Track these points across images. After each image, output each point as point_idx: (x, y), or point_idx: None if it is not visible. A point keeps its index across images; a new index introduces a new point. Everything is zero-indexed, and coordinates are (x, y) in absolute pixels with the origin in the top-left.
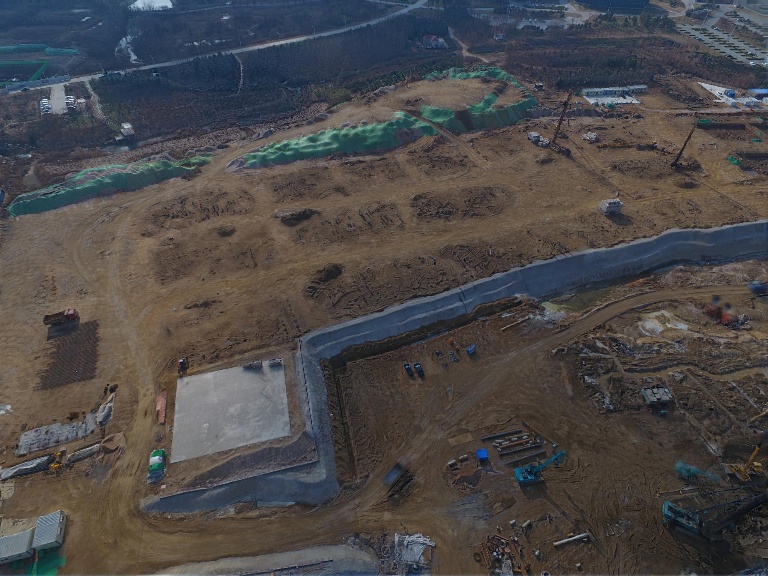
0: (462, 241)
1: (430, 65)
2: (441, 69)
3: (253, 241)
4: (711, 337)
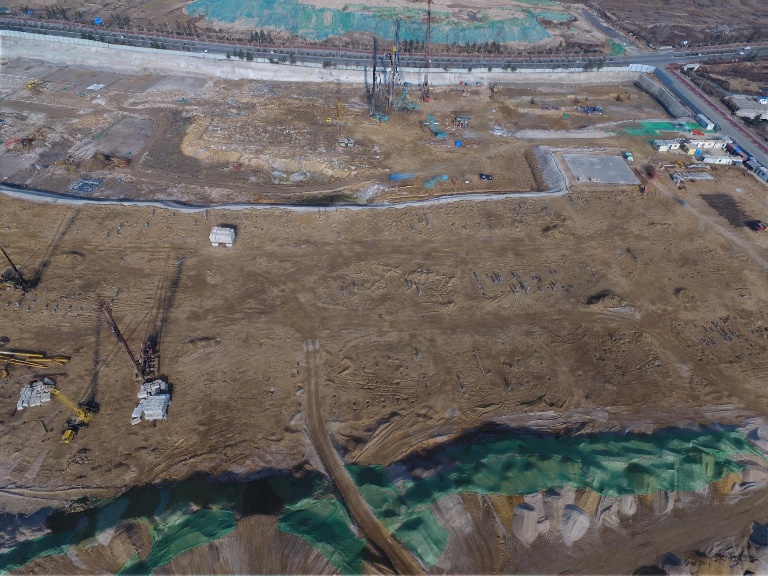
0: (416, 239)
1: None
2: None
3: (645, 277)
4: (269, 162)
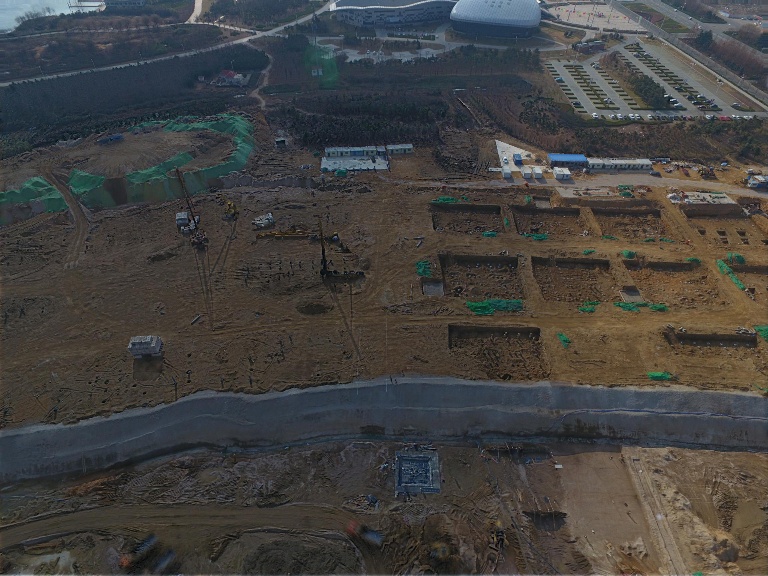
0: None
1: (182, 109)
2: (184, 116)
3: None
4: None
